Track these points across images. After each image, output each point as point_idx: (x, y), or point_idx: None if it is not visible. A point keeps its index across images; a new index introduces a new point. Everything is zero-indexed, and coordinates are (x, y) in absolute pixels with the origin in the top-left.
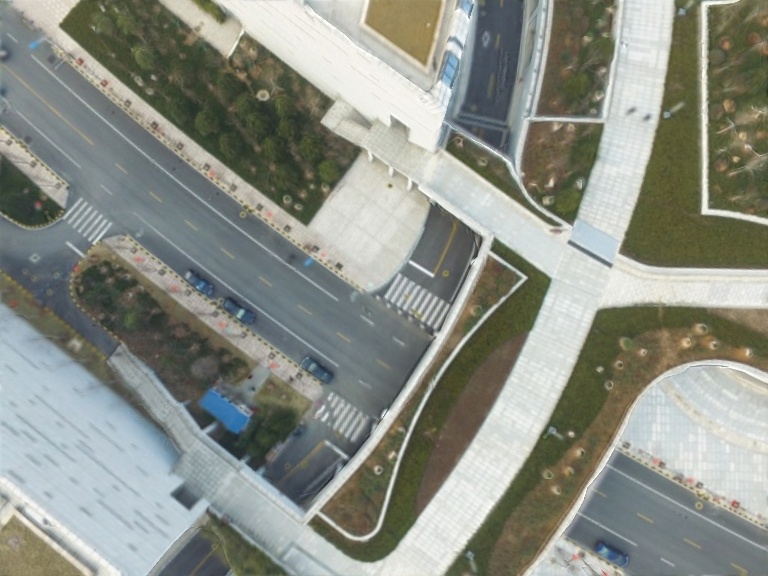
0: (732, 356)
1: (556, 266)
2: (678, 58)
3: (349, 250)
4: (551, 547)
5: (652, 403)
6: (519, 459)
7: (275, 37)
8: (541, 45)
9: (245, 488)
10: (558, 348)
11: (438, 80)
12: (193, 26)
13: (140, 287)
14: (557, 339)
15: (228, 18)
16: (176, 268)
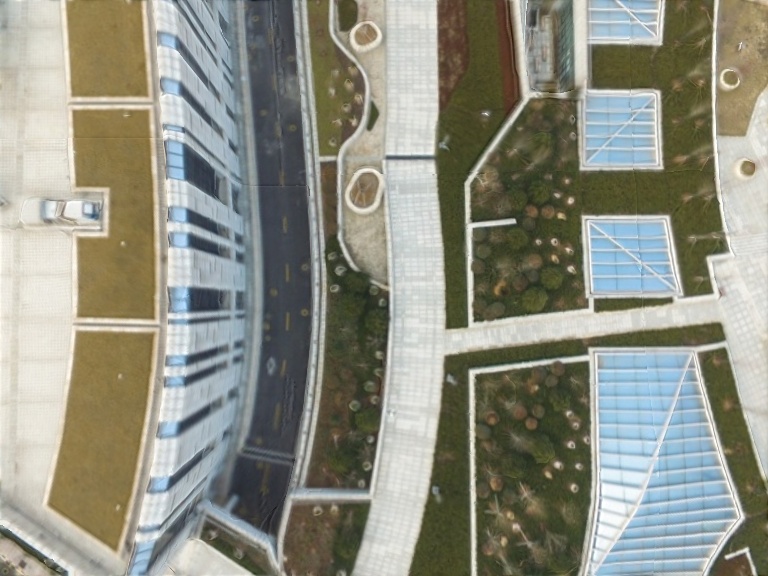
0: None
1: None
2: (447, 428)
3: None
4: None
5: None
6: None
7: None
8: (311, 404)
9: None
10: None
11: (127, 573)
12: None
13: None
14: None
15: None
16: None
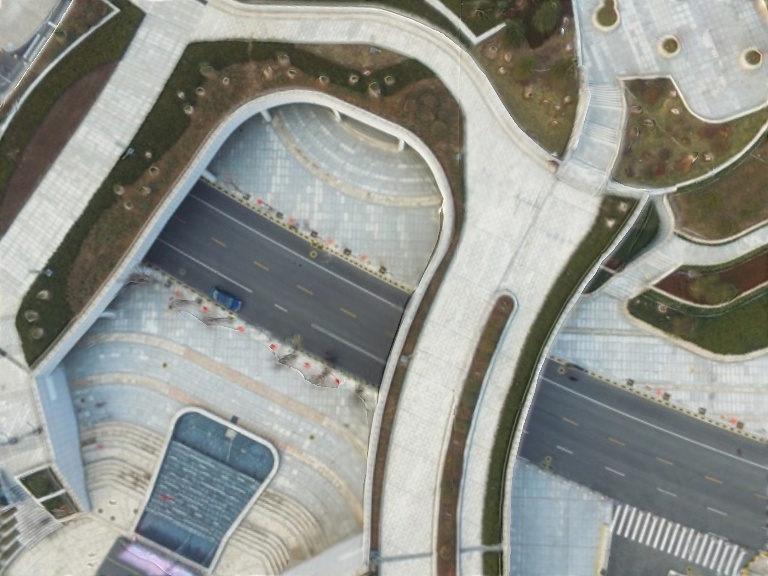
0: (311, 85)
1: (152, 2)
2: None
3: None
4: (127, 264)
5: (273, 157)
6: (99, 180)
7: None
8: None
9: None
10: (147, 78)
11: None
12: None
13: None
14: (147, 69)
15: None
16: None
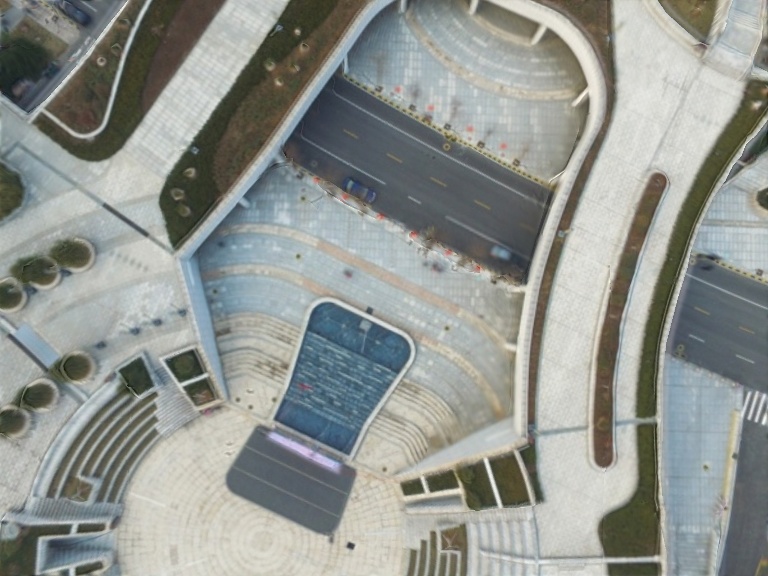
0: None
1: None
2: None
3: None
4: (275, 143)
5: (405, 49)
6: (246, 56)
7: None
8: None
9: None
10: None
11: None
12: None
13: None
14: None
15: None
16: None
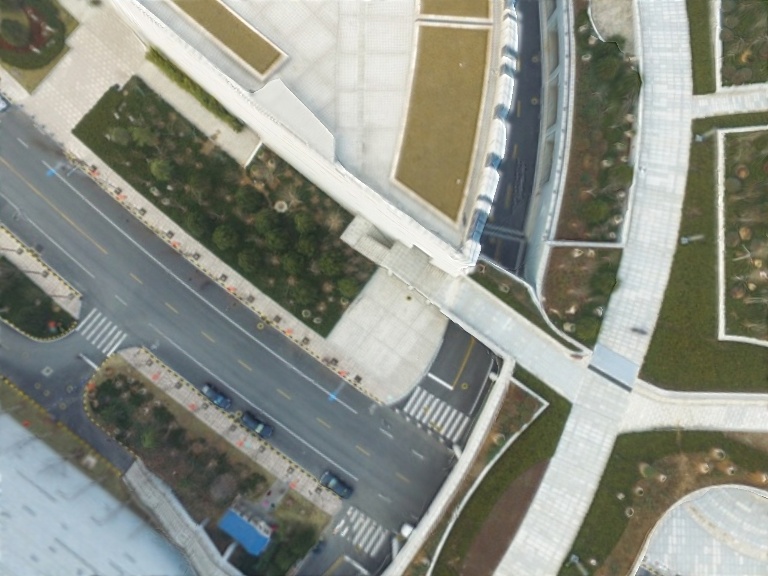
0: (749, 481)
1: (577, 391)
2: (695, 184)
3: (368, 363)
4: None
5: (668, 516)
6: None
7: (296, 159)
8: (560, 166)
9: None
10: (579, 474)
11: (468, 238)
12: (209, 134)
13: (156, 402)
14: (578, 465)
15: (245, 129)
16: (193, 380)
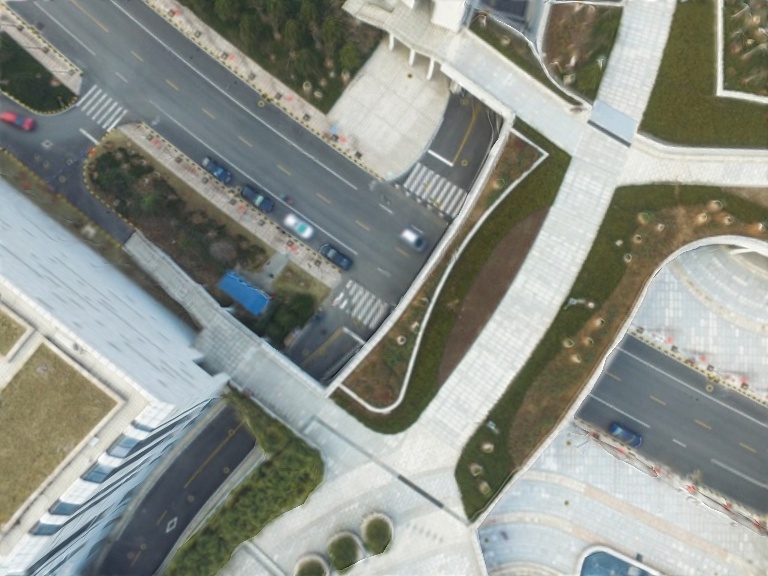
0: (745, 231)
1: (576, 145)
2: None
3: (368, 139)
4: (571, 416)
5: (665, 289)
6: (540, 330)
7: None
8: None
9: (266, 361)
10: (578, 223)
11: None
12: None
13: (156, 173)
14: (577, 215)
15: None
16: (193, 156)
